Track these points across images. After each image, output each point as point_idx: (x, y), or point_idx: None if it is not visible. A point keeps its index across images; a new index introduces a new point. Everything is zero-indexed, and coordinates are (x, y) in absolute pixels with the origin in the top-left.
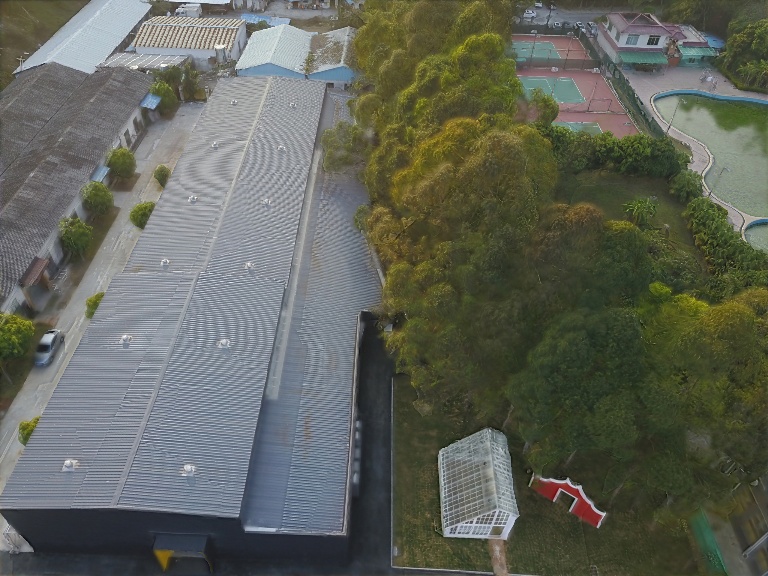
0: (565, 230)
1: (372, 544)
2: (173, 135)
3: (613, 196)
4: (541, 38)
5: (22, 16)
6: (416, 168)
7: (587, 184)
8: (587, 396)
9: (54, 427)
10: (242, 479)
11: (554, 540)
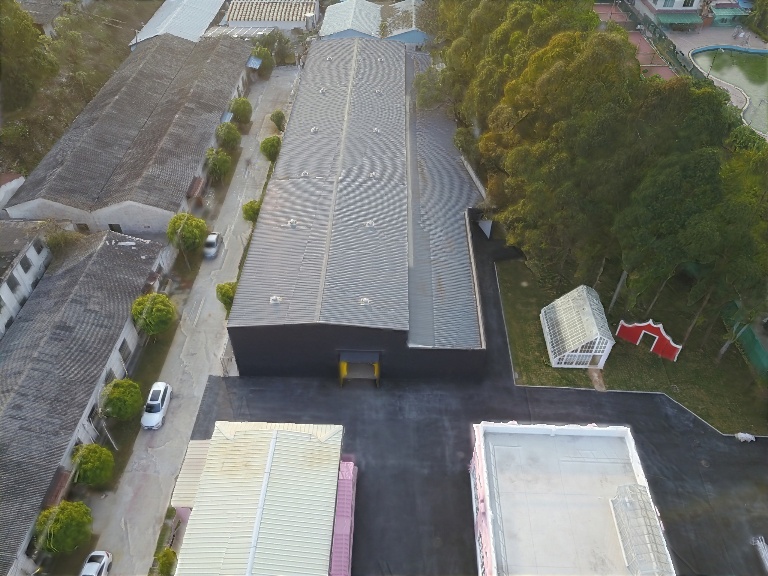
0: (660, 95)
1: (497, 371)
2: (273, 92)
3: None
4: None
5: None
6: (524, 76)
7: None
8: (679, 217)
9: (254, 278)
10: (406, 308)
11: (640, 369)
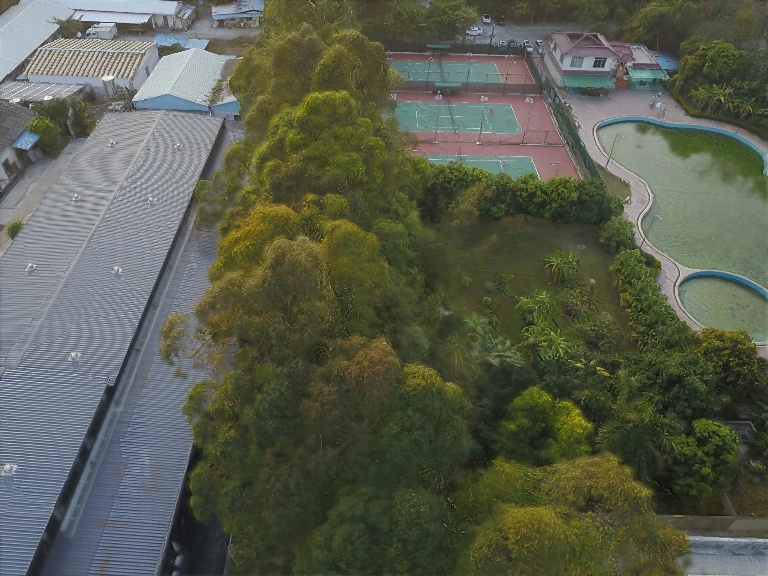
0: (344, 384)
1: None
2: (53, 177)
3: (537, 245)
4: (484, 58)
5: None
6: None
7: (510, 231)
8: None
9: None
10: None
11: None
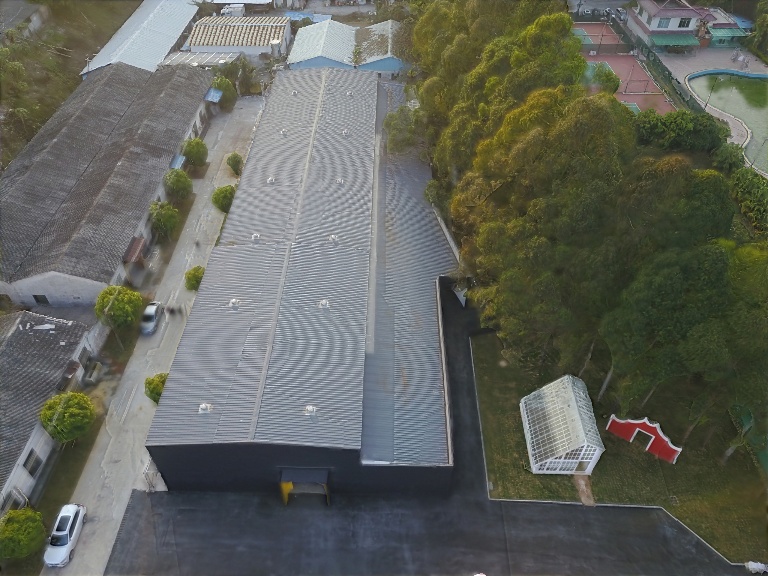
0: (656, 179)
1: (469, 480)
2: (235, 127)
3: None
4: None
5: (80, 21)
6: (499, 137)
7: None
8: (680, 326)
9: (184, 378)
10: (359, 417)
11: (634, 475)
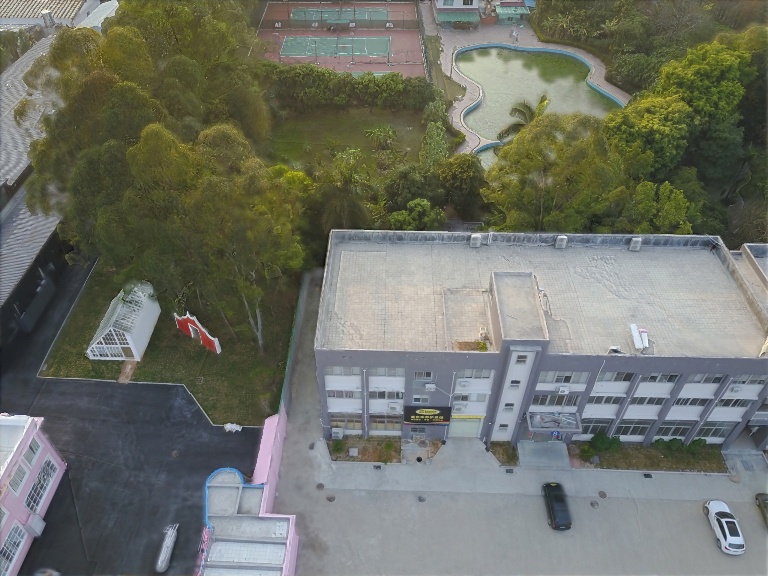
0: (81, 89)
1: (28, 363)
2: None
3: (374, 128)
4: (380, 5)
5: None
6: None
7: (356, 119)
8: None
9: None
10: None
11: (179, 361)
